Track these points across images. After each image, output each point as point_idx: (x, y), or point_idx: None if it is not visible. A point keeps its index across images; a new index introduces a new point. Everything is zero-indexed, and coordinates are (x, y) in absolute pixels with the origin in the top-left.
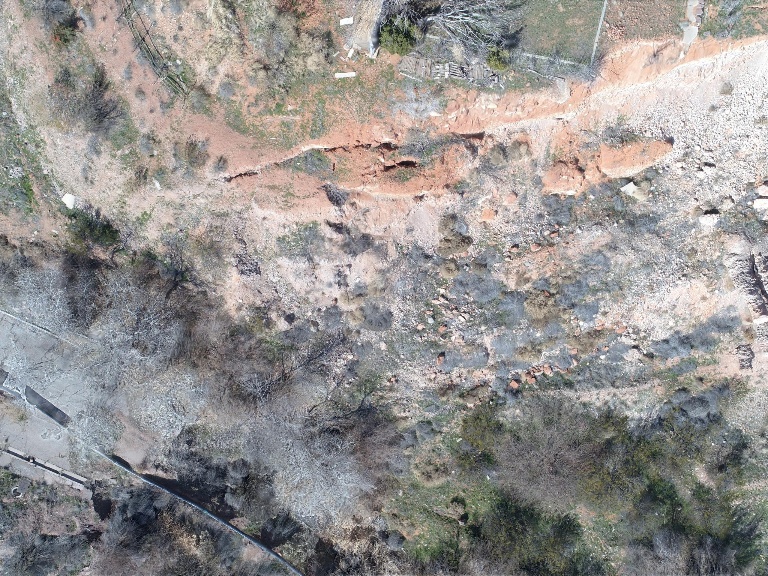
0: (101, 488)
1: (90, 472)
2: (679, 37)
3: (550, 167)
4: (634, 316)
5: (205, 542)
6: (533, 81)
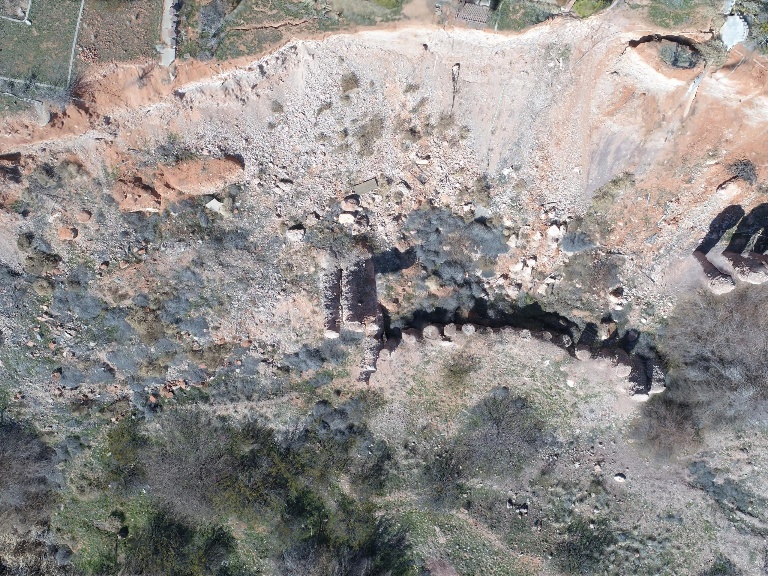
0: None
1: None
2: (157, 59)
3: (113, 186)
4: (252, 330)
5: None
6: (12, 104)
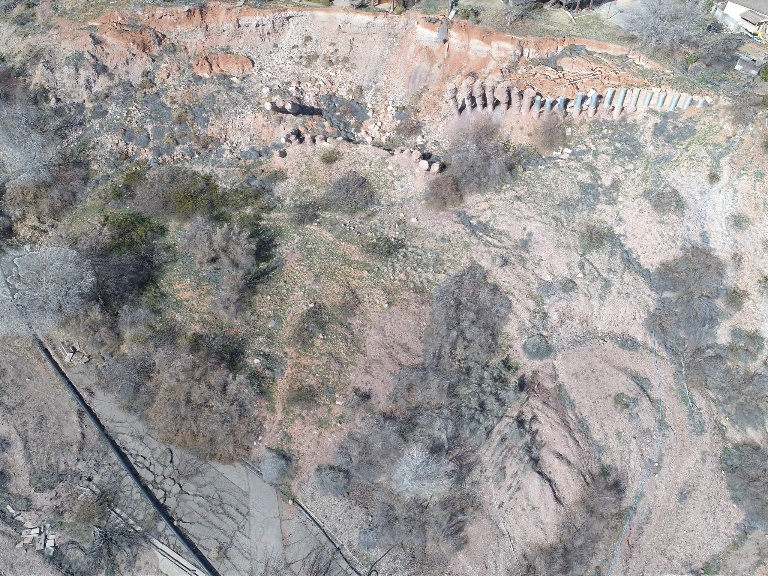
0: None
1: None
2: (236, 4)
3: None
4: (229, 132)
5: None
6: None
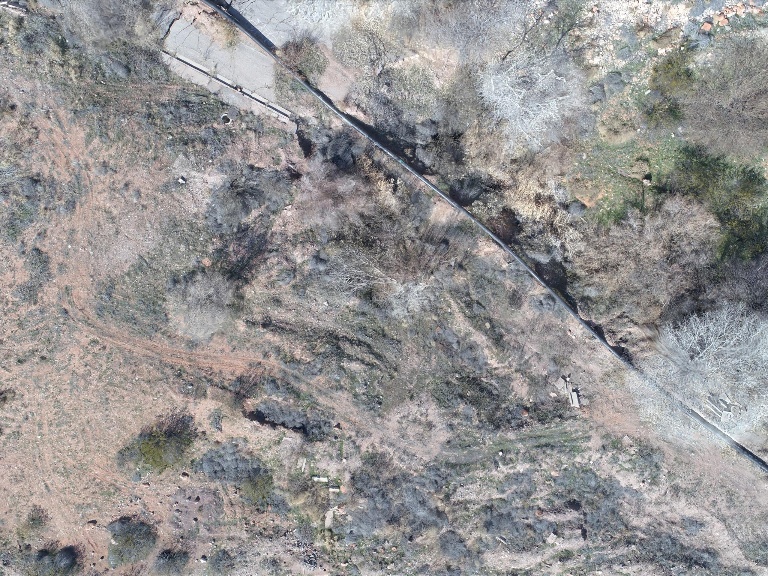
0: (303, 125)
1: (294, 106)
2: None
3: None
4: None
5: (401, 189)
6: None
